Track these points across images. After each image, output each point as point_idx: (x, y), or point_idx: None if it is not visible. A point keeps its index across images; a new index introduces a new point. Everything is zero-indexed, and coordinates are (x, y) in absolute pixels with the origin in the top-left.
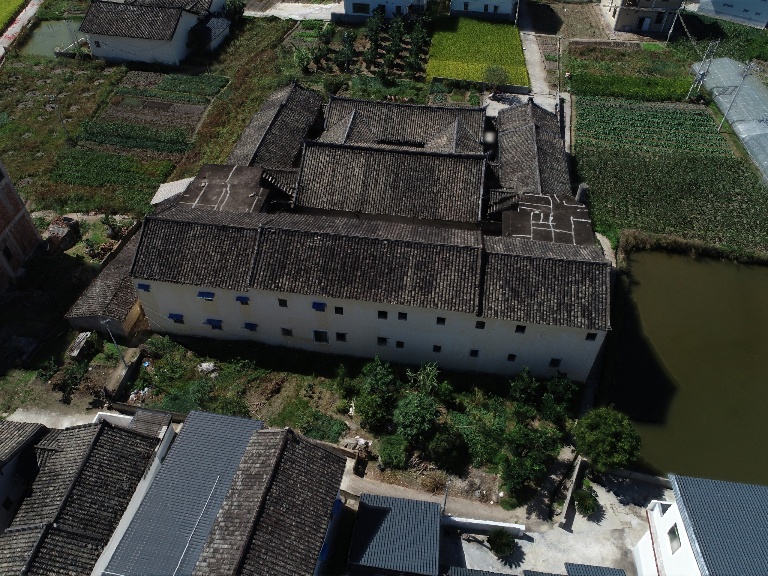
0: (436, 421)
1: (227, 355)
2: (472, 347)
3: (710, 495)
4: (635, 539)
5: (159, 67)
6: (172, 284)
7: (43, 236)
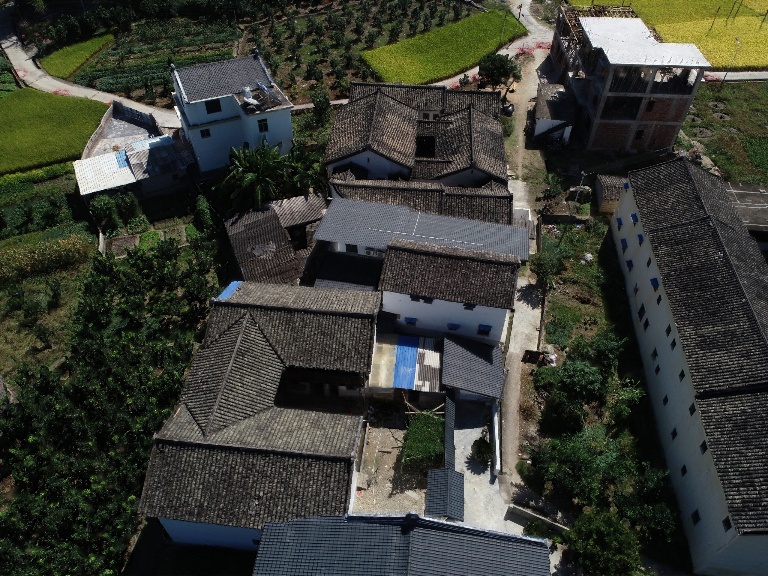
0: (576, 390)
1: (605, 266)
2: (677, 426)
3: (531, 575)
4: None
5: None
6: (633, 195)
7: (675, 152)
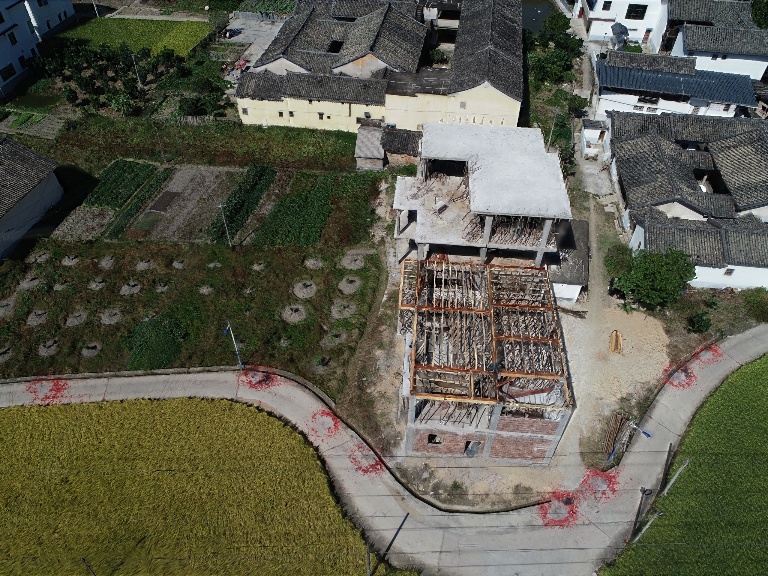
0: None
1: (525, 121)
2: None
3: None
4: (584, 39)
5: (60, 210)
6: None
7: None
